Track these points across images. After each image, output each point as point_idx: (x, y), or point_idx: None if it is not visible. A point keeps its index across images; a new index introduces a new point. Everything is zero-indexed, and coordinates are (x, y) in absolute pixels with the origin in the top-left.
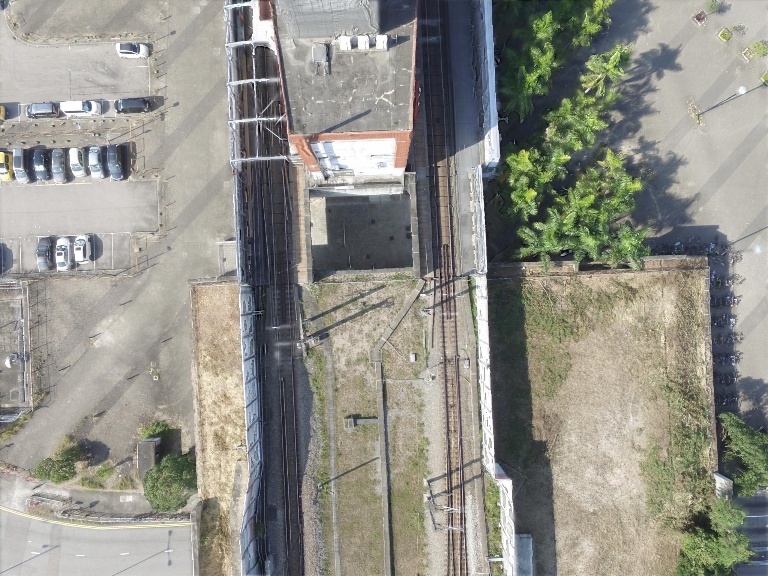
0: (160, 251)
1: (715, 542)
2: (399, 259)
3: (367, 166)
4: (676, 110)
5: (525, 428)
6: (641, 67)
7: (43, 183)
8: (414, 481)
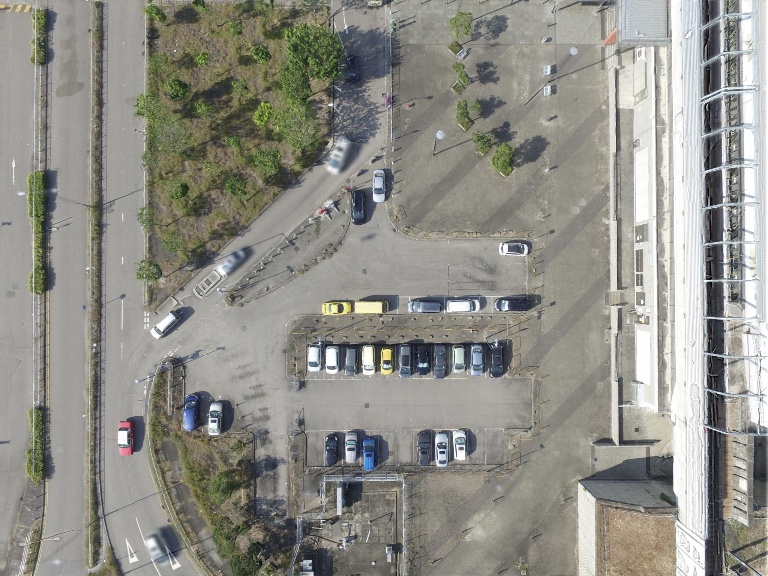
0: (533, 449)
1: None
2: (766, 466)
3: None
4: None
5: None
6: None
7: (420, 377)
8: None
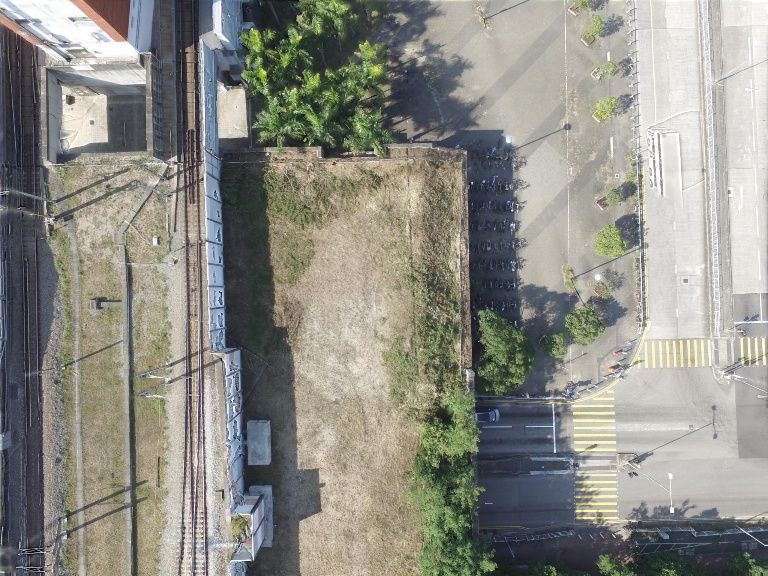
0: None
1: (452, 432)
2: None
3: (90, 40)
4: (462, 13)
5: (267, 314)
6: None
7: None
8: (157, 365)
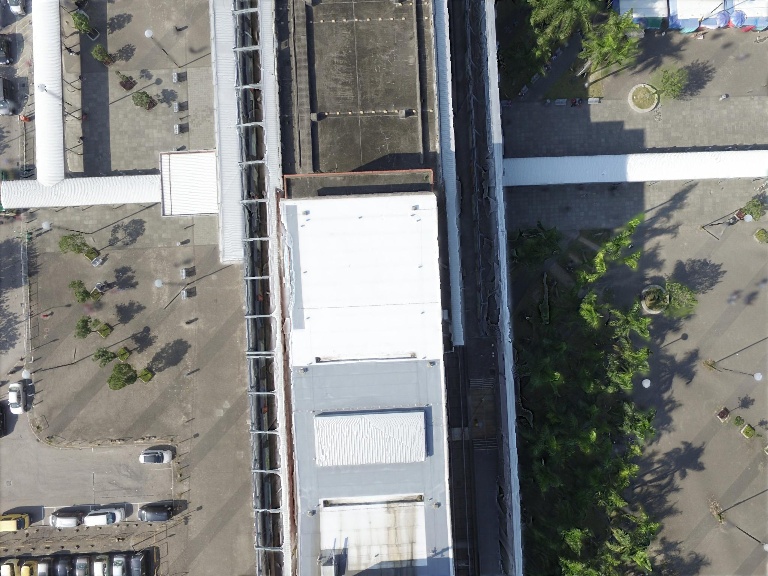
0: None
1: None
2: None
3: None
4: (698, 509)
5: None
6: (663, 467)
7: None
8: None
